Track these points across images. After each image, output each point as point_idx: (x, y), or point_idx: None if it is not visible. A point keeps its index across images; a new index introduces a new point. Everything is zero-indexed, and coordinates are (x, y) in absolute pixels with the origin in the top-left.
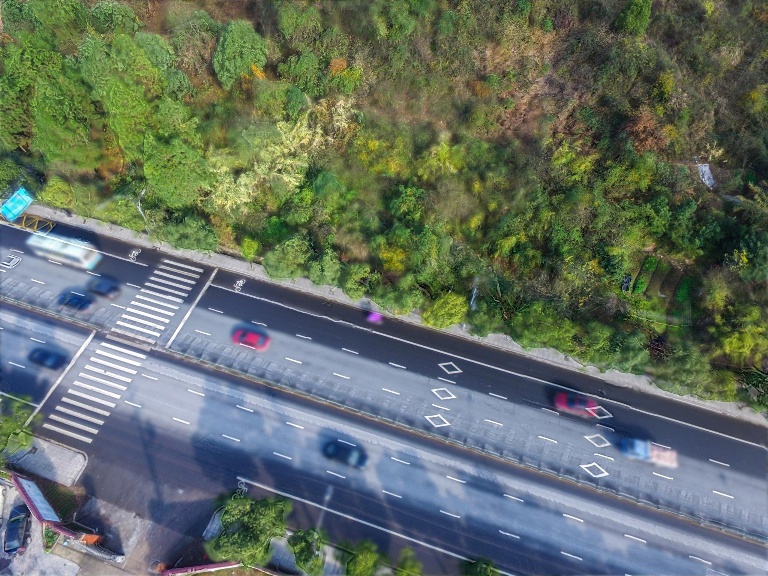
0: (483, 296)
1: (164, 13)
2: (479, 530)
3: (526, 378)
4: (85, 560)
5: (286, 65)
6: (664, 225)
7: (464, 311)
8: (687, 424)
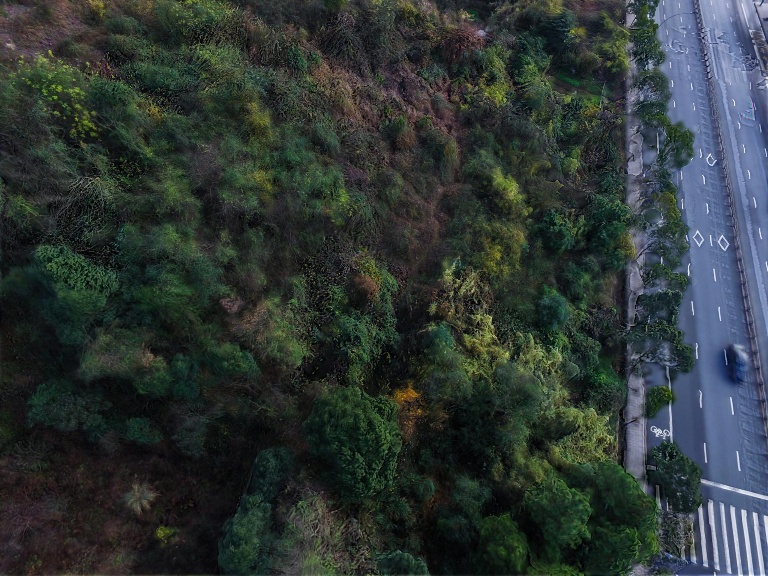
0: None
1: None
2: None
3: None
4: None
5: (352, 367)
6: (534, 66)
7: None
8: None
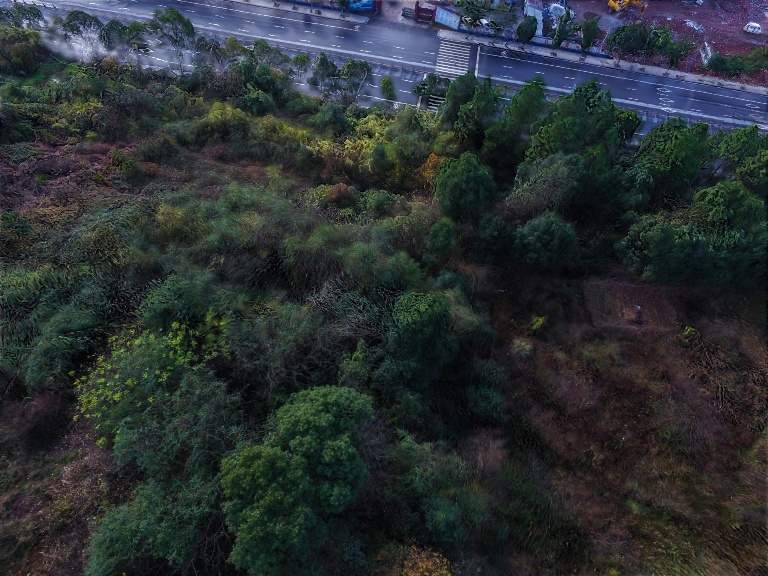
0: None
1: (678, 377)
2: (235, 17)
3: (188, 65)
4: None
5: (408, 203)
6: None
7: None
8: None
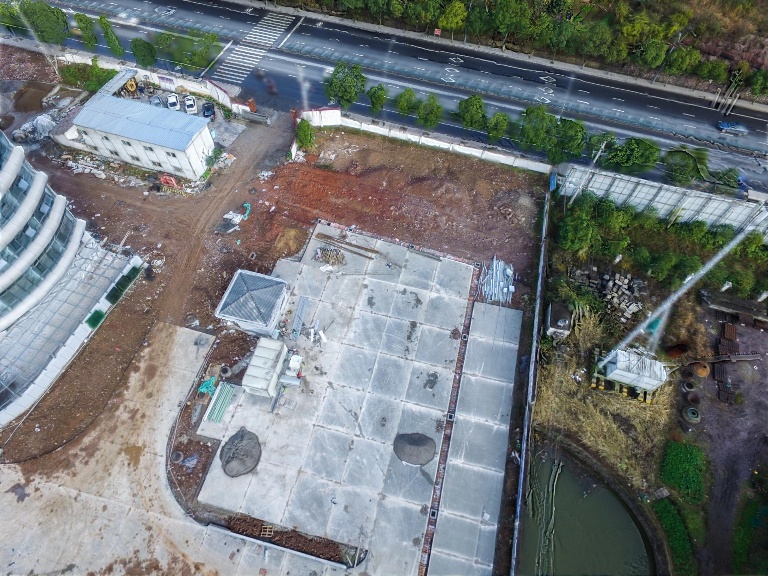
0: (477, 5)
1: None
2: None
3: (504, 66)
4: (249, 124)
5: None
6: None
7: (465, 15)
8: (602, 85)
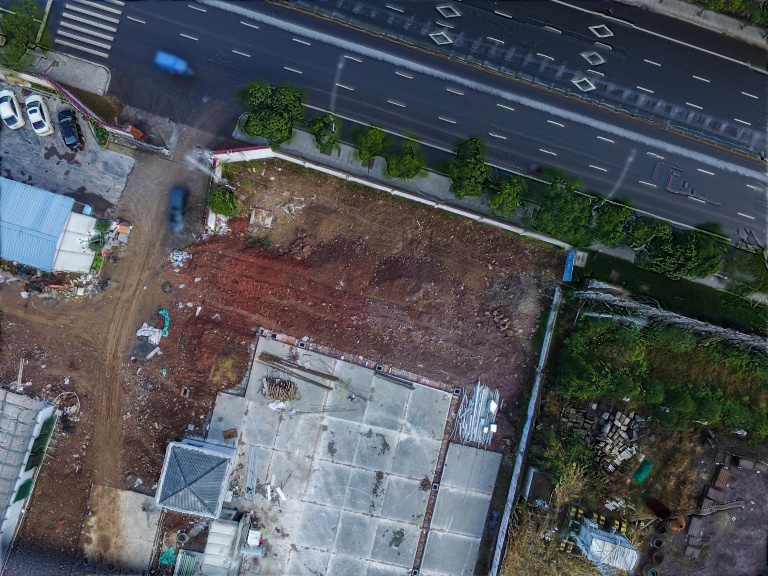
0: None
1: None
2: (472, 133)
3: None
4: (137, 154)
5: None
6: None
7: None
8: (684, 43)
